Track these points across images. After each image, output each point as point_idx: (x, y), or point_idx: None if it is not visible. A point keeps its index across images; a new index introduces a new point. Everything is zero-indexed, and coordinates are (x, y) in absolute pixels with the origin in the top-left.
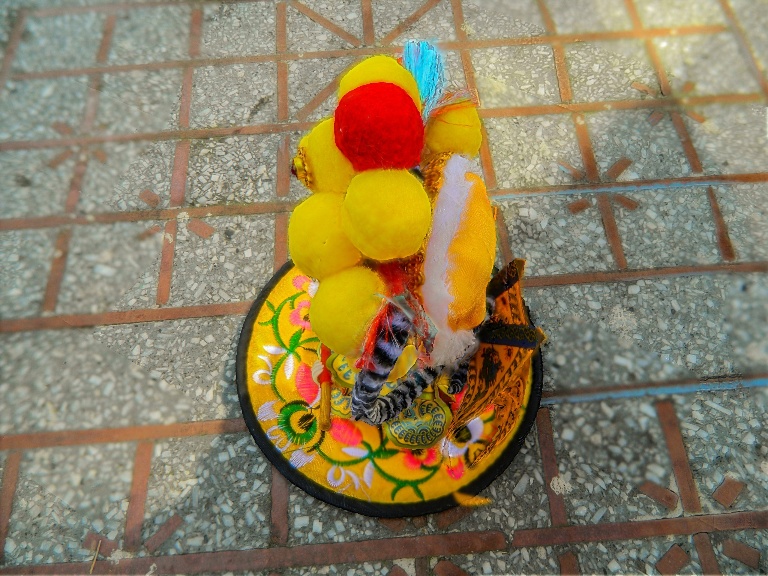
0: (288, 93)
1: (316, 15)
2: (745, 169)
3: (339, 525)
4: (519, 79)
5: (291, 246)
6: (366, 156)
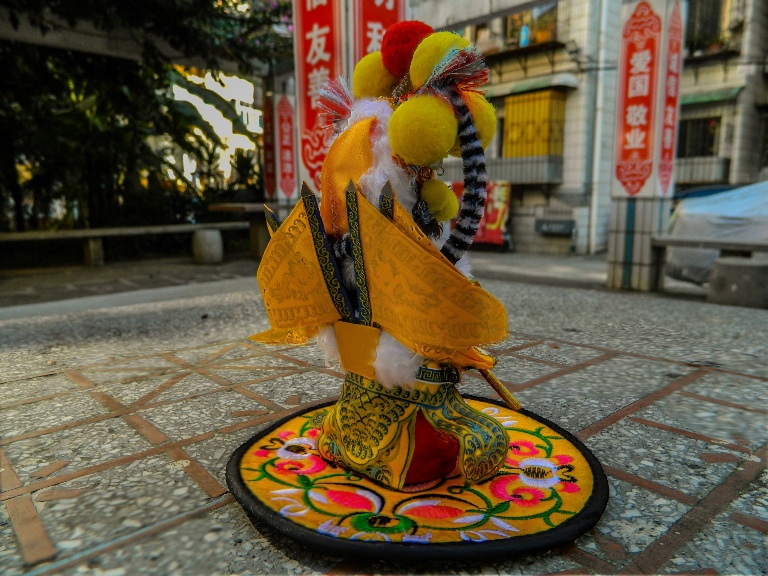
0: None
1: None
2: None
3: None
4: None
5: None
6: None
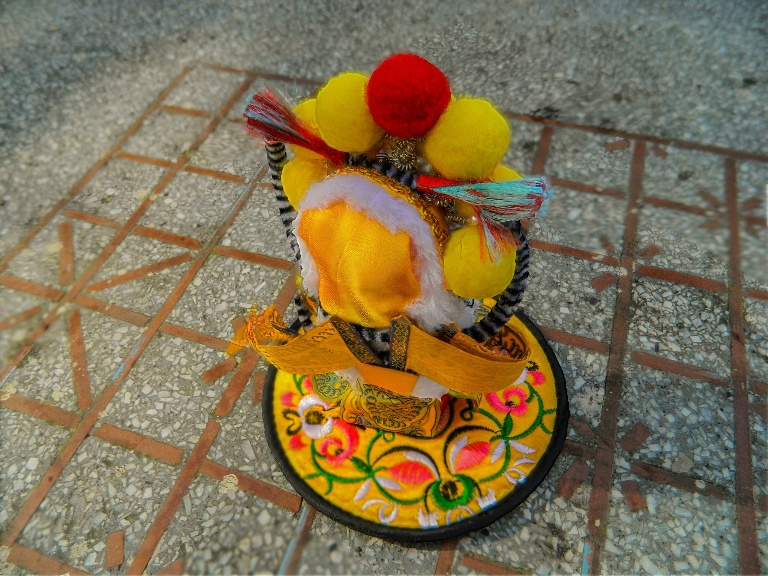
0: None
1: None
2: None
3: None
4: None
5: None
6: None
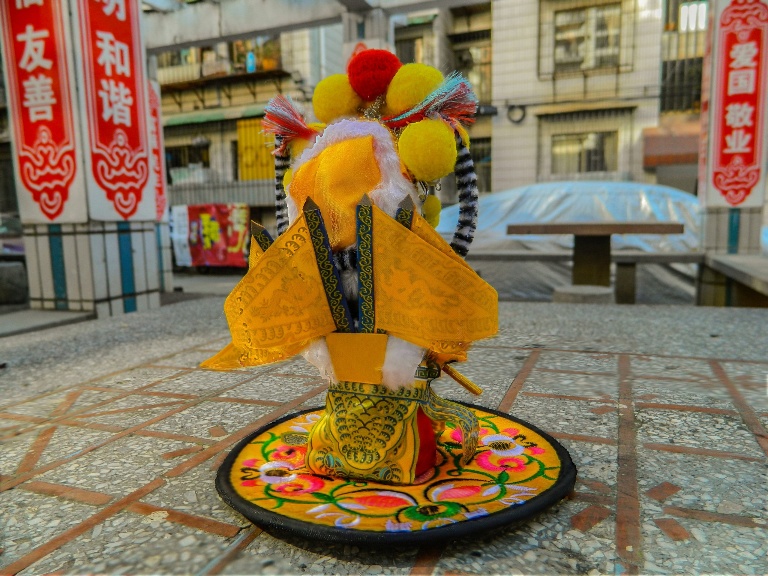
0: None
1: None
2: None
3: None
4: None
5: None
6: None
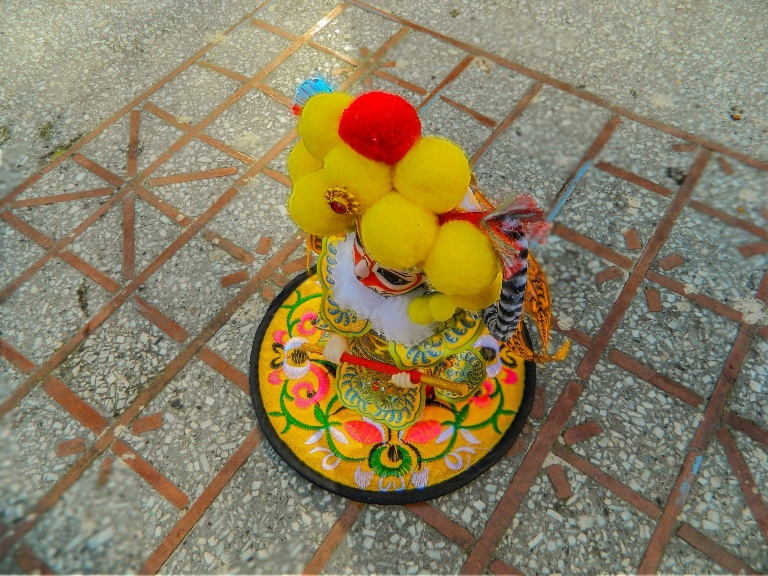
0: (96, 269)
1: (48, 198)
2: (446, 72)
3: (490, 488)
4: (259, 124)
5: (394, 251)
6: (402, 144)
